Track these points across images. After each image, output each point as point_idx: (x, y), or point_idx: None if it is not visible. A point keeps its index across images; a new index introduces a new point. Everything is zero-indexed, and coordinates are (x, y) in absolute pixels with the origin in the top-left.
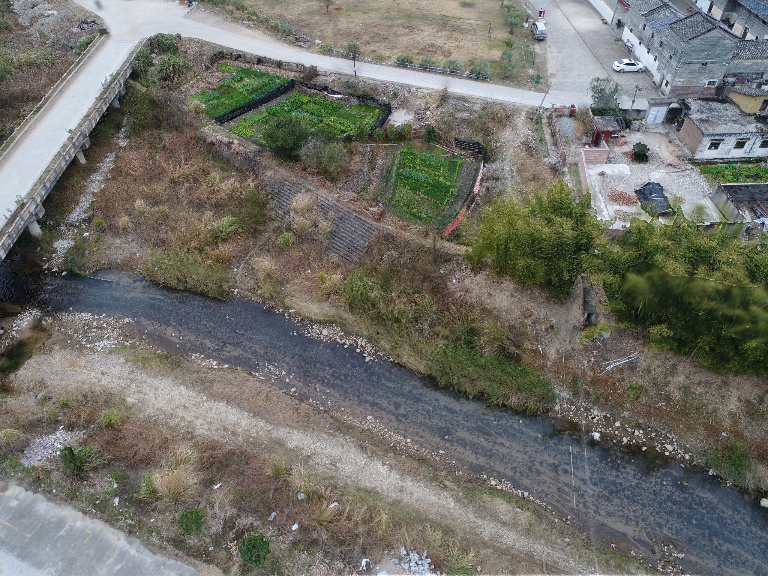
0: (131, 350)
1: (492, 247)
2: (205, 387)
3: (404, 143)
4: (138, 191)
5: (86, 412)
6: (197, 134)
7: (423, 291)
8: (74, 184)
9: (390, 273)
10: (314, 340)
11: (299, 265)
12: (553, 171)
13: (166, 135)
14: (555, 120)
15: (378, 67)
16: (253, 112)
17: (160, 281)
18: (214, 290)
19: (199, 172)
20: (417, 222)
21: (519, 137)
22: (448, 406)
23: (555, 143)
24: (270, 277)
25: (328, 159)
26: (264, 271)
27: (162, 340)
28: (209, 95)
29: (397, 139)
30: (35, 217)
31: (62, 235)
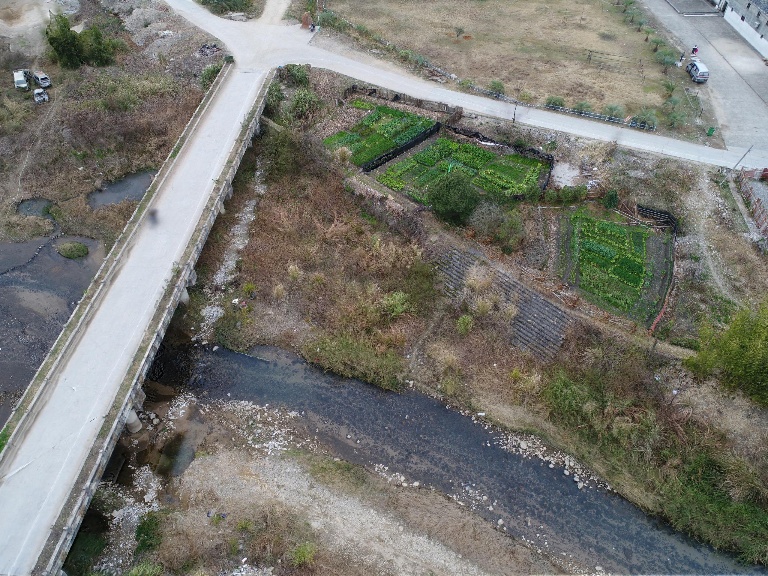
0: (305, 455)
1: (739, 364)
2: (399, 513)
3: (576, 206)
4: (288, 252)
5: (271, 542)
6: (343, 184)
7: (641, 404)
8: (218, 240)
9: (599, 378)
10: (512, 454)
11: (483, 356)
12: (756, 250)
13: (306, 182)
14: (750, 187)
15: (527, 110)
16: (399, 159)
17: (324, 365)
18: (387, 381)
19: (353, 232)
20: (613, 310)
21: (708, 205)
22: (689, 558)
23: (752, 214)
24: (451, 370)
25: (509, 230)
26: (445, 362)
27: (337, 443)
28: (349, 137)
29: (567, 200)
30: (188, 284)
31: (208, 300)
